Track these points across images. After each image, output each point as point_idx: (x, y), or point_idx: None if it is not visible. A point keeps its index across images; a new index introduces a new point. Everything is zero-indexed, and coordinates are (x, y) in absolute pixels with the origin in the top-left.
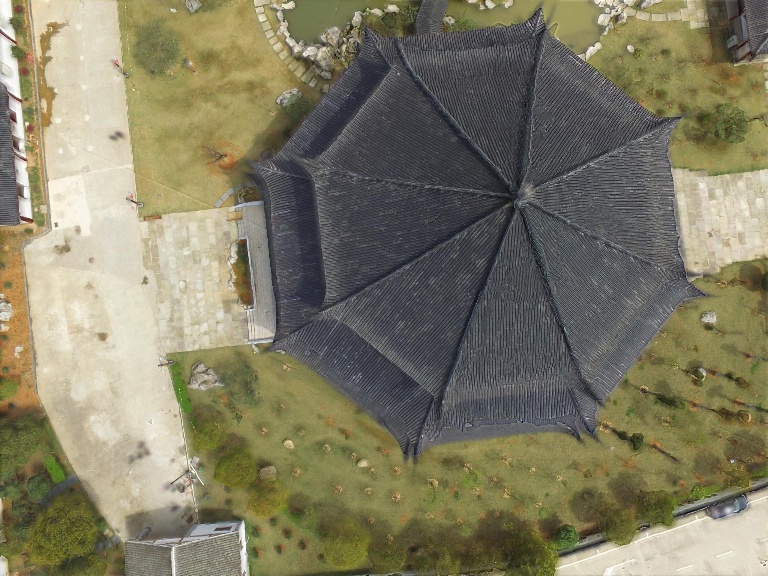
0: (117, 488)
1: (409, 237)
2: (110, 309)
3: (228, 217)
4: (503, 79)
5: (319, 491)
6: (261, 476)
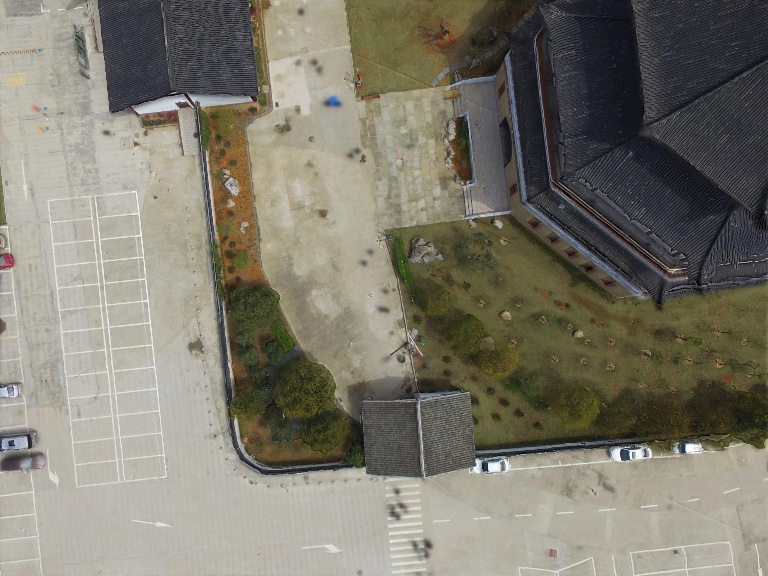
0: (339, 359)
1: (748, 45)
2: (330, 186)
3: (444, 96)
4: None
5: (535, 362)
6: (481, 346)
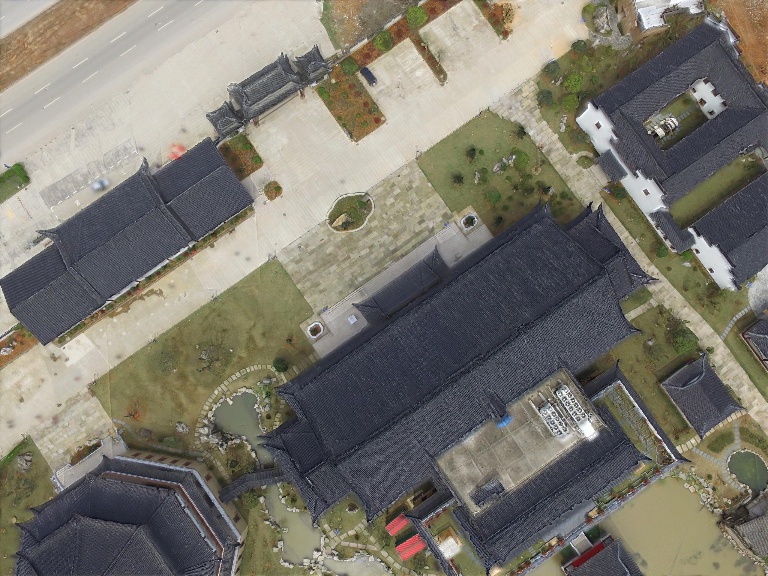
0: None
1: None
2: (37, 396)
3: (110, 429)
4: (147, 575)
5: (0, 546)
6: None
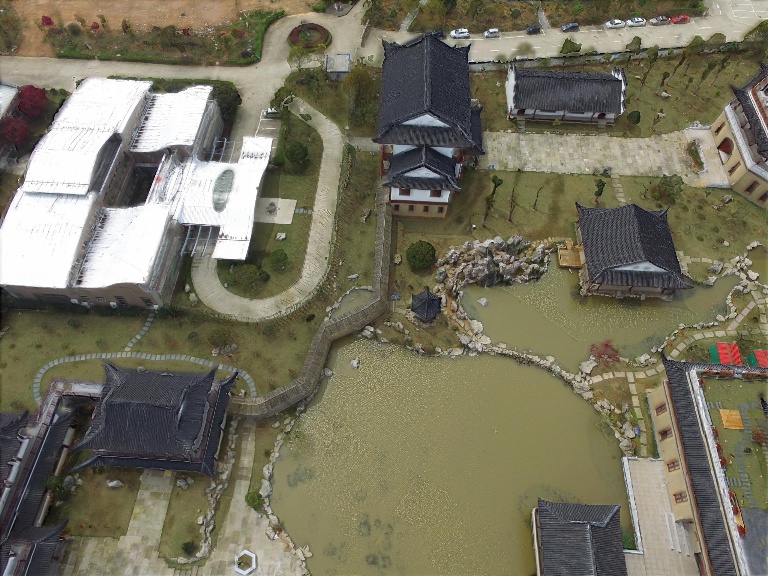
0: None
1: None
2: None
3: None
4: None
5: None
6: None
